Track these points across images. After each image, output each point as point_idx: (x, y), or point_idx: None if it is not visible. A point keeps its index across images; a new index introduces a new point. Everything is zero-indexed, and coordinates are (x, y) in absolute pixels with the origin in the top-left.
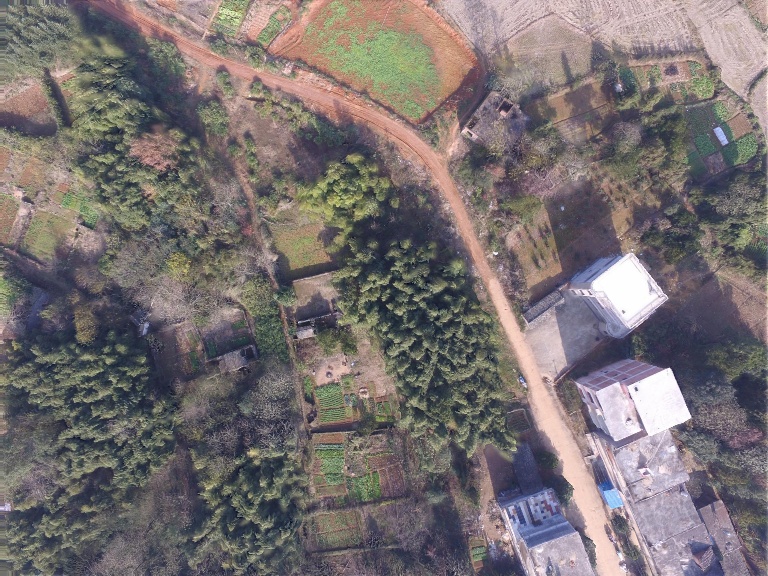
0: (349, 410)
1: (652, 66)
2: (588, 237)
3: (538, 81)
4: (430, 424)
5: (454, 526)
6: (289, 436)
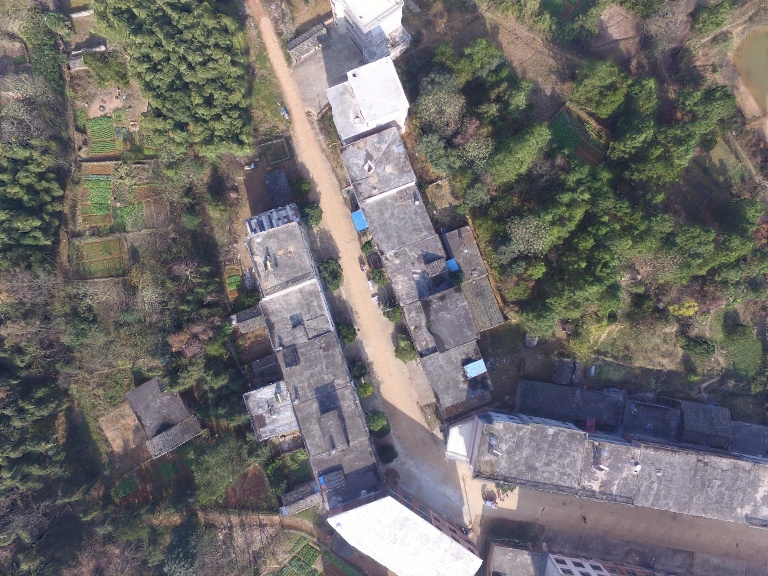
0: (119, 142)
1: None
2: None
3: None
4: (165, 122)
5: (212, 256)
6: (33, 135)
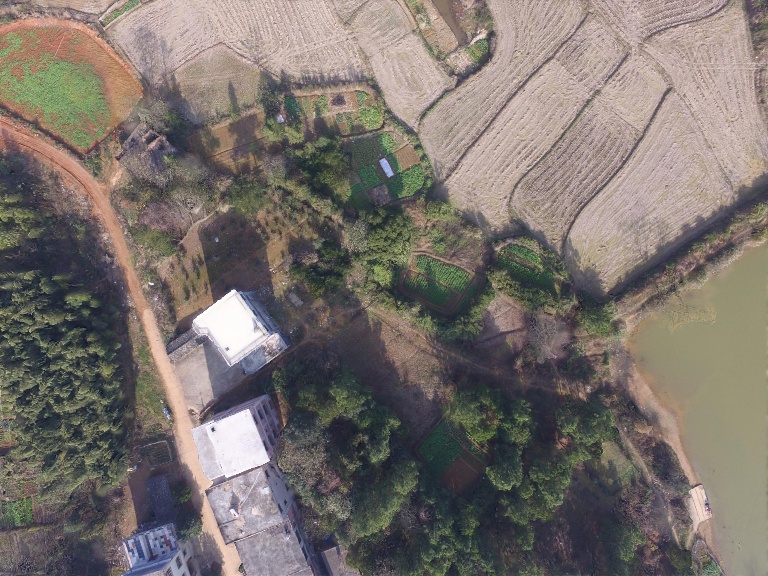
0: (7, 435)
1: (319, 96)
2: (241, 269)
3: (204, 111)
4: None
5: (99, 555)
6: None
